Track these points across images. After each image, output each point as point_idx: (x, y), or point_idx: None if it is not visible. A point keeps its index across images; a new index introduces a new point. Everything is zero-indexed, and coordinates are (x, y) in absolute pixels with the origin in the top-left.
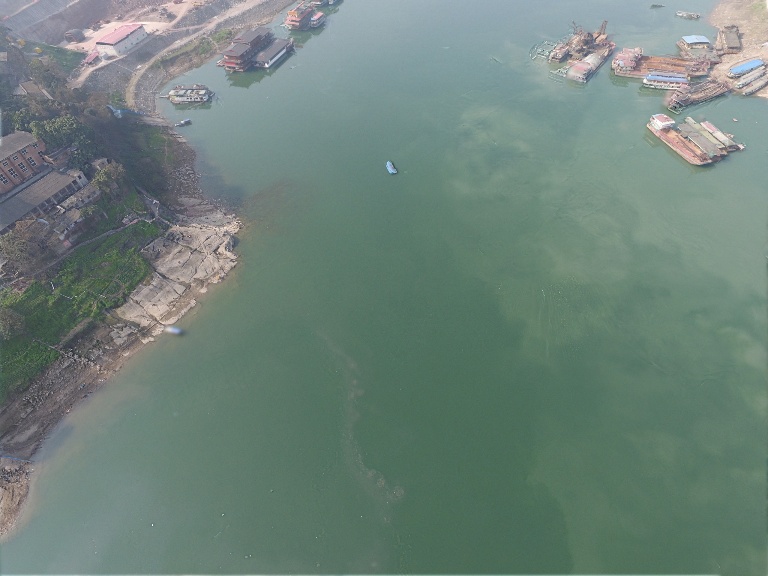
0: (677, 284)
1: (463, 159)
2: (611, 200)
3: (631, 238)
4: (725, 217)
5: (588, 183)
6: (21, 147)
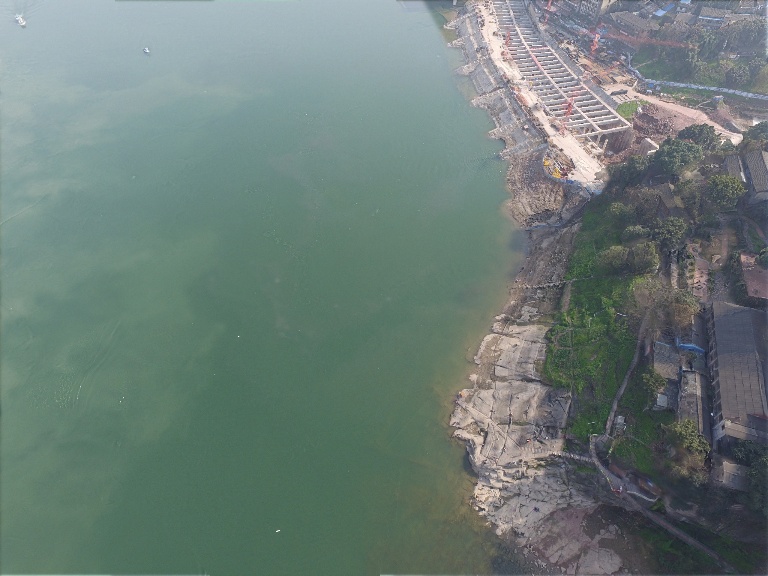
0: None
1: None
2: None
3: None
4: None
5: None
6: None
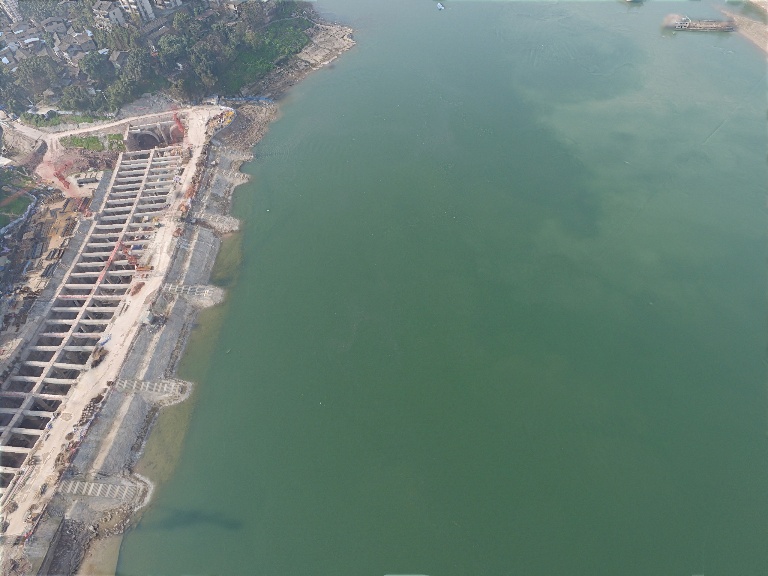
0: (608, 42)
1: (486, 1)
2: (576, 14)
3: (585, 27)
4: (643, 21)
5: None
6: None
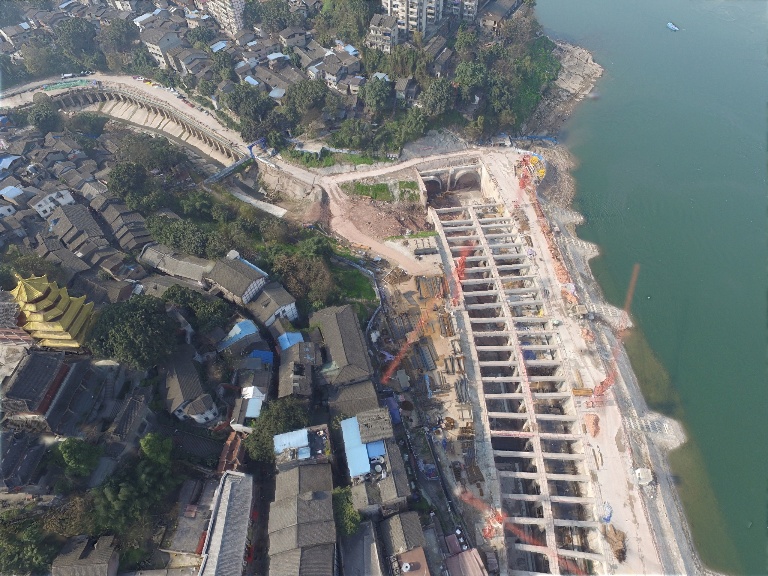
0: None
1: (723, 23)
2: None
3: None
4: None
5: None
6: None
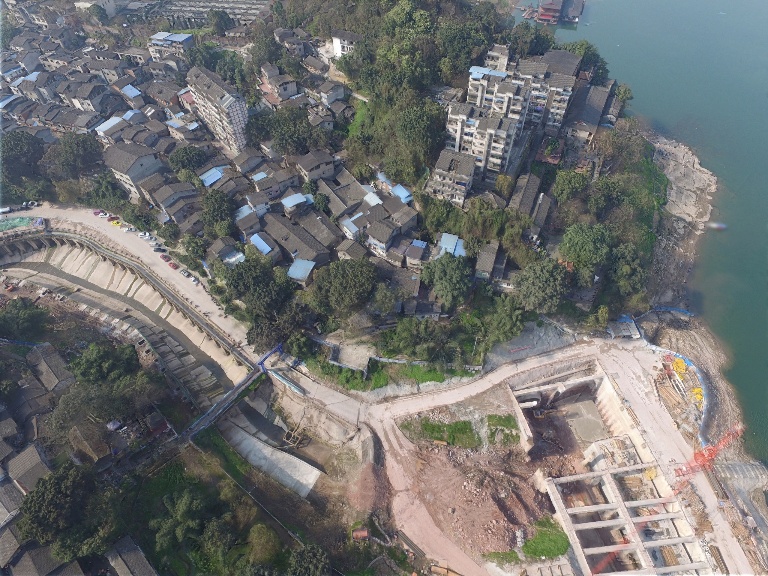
0: None
1: None
2: None
3: None
4: None
5: None
6: (576, 62)
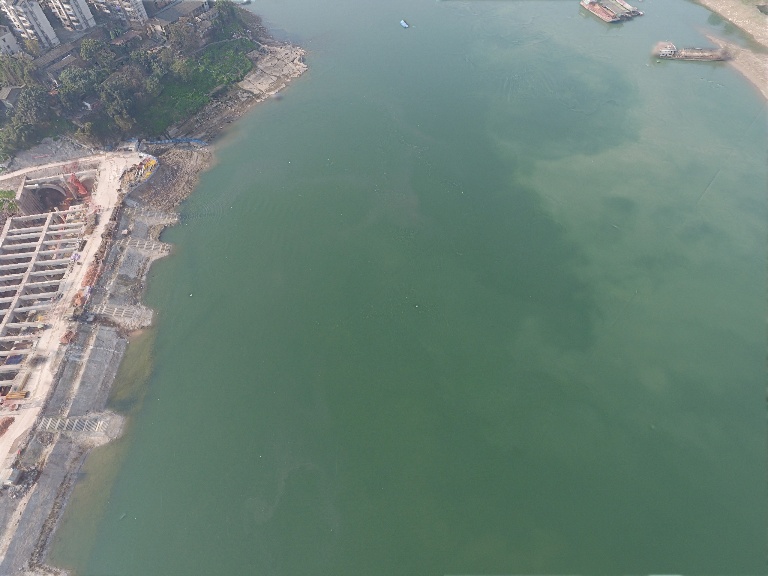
0: (588, 72)
1: (454, 19)
2: (552, 36)
3: (563, 53)
4: (624, 47)
5: (538, 30)
6: None
